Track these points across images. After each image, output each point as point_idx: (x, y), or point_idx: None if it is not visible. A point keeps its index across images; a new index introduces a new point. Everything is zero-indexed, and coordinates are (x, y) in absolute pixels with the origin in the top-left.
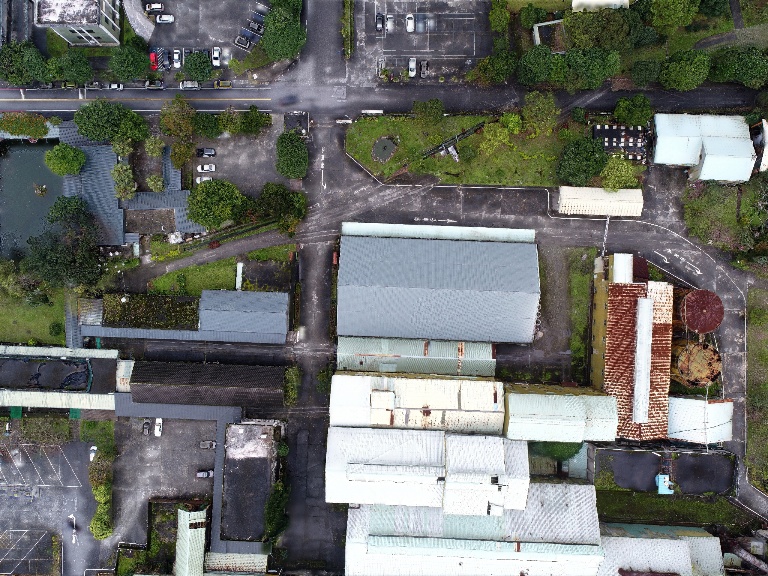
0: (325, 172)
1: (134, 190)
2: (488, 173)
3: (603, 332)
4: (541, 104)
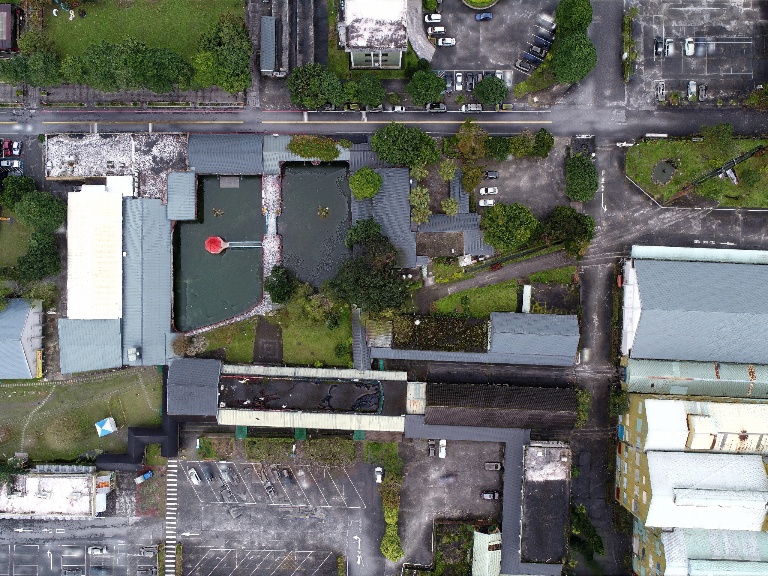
0: (605, 195)
1: (430, 213)
2: (767, 196)
3: None
4: None
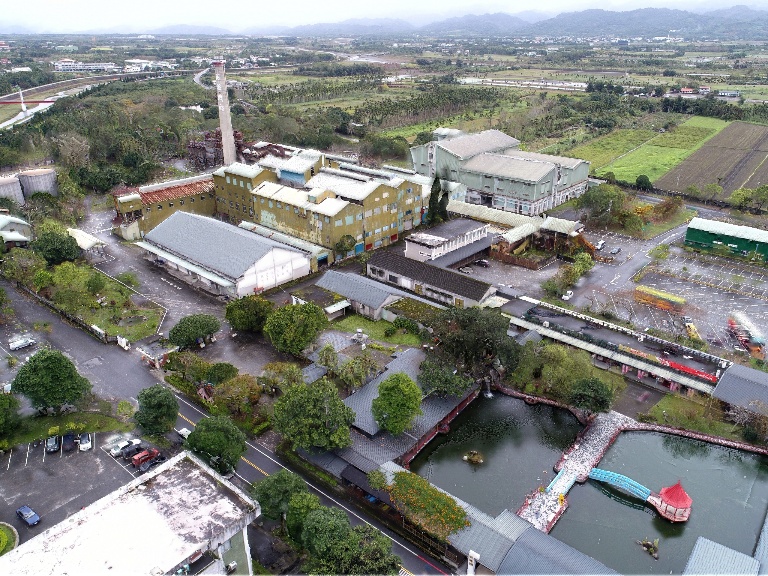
0: None
1: None
2: None
3: (178, 205)
4: (20, 252)
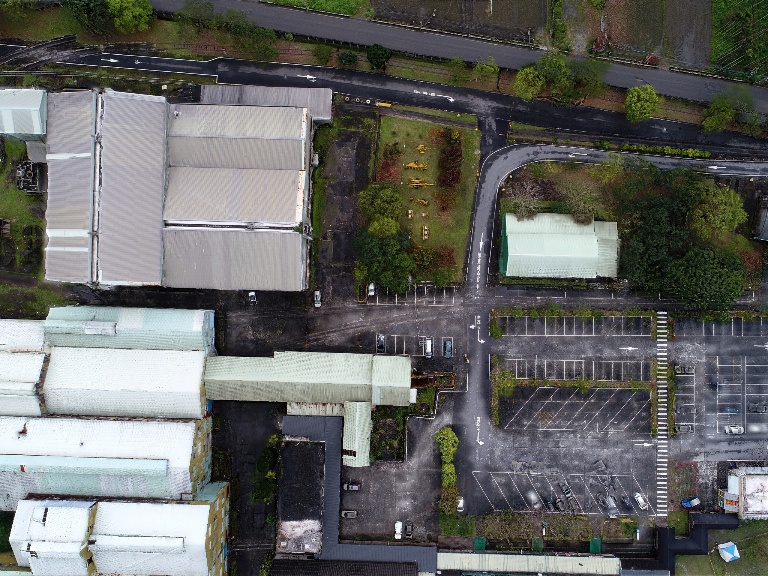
0: None
1: None
2: None
3: None
4: None
